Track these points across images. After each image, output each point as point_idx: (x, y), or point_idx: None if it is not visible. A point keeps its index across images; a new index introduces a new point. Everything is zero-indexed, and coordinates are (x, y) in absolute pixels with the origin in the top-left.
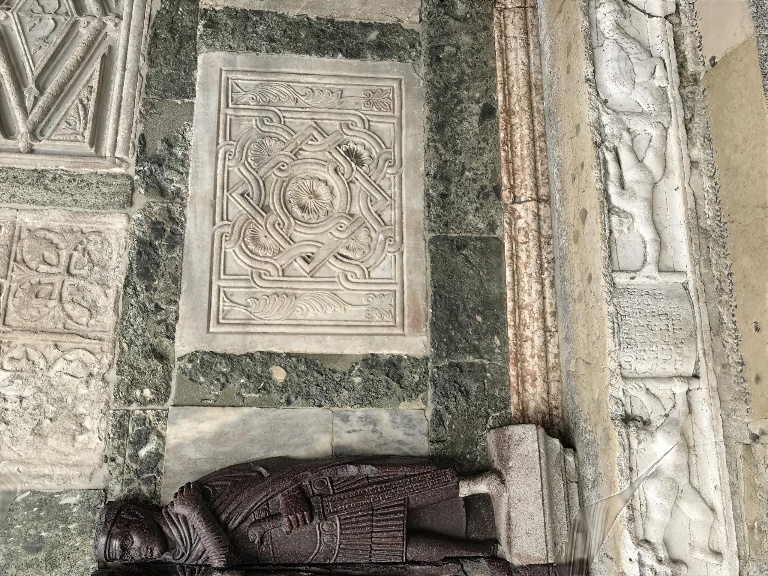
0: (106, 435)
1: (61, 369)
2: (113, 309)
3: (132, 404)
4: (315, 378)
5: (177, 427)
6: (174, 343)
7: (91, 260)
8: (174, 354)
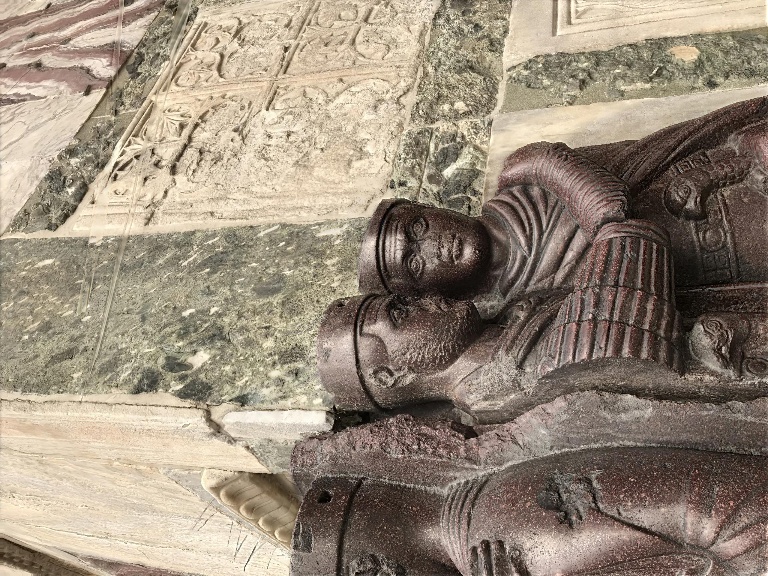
0: (395, 157)
1: (344, 101)
2: (418, 40)
3: (437, 122)
4: (760, 51)
5: (507, 134)
6: (502, 56)
7: (395, 11)
8: (502, 66)
